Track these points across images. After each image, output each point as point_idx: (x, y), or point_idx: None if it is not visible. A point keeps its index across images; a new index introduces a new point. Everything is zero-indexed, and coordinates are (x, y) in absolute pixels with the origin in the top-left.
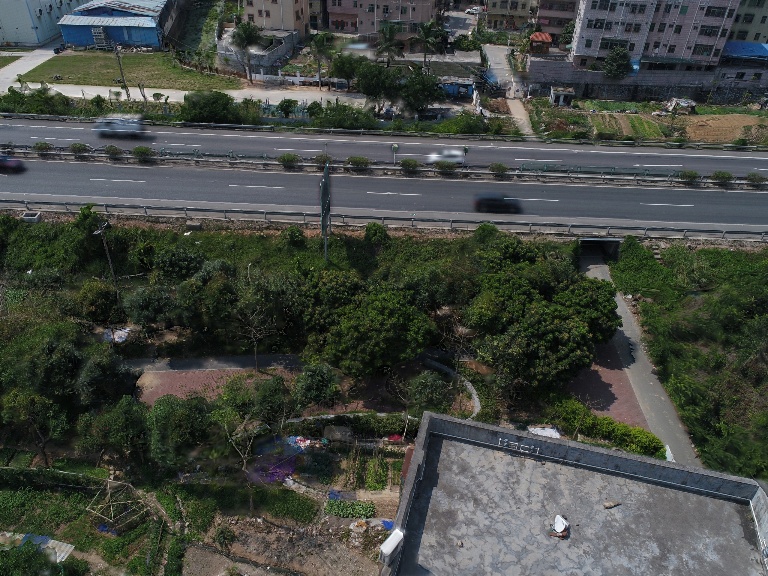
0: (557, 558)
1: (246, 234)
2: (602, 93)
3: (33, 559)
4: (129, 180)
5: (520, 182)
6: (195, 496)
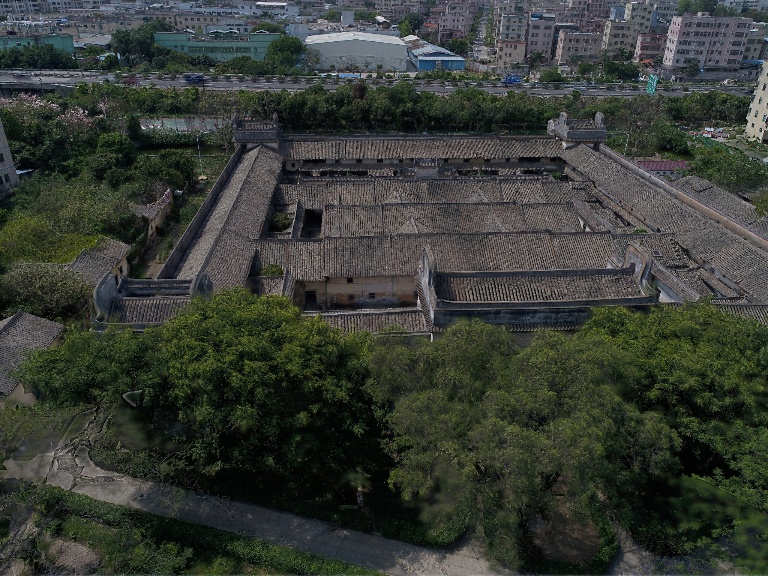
0: None
1: None
2: None
3: None
4: None
5: None
6: None
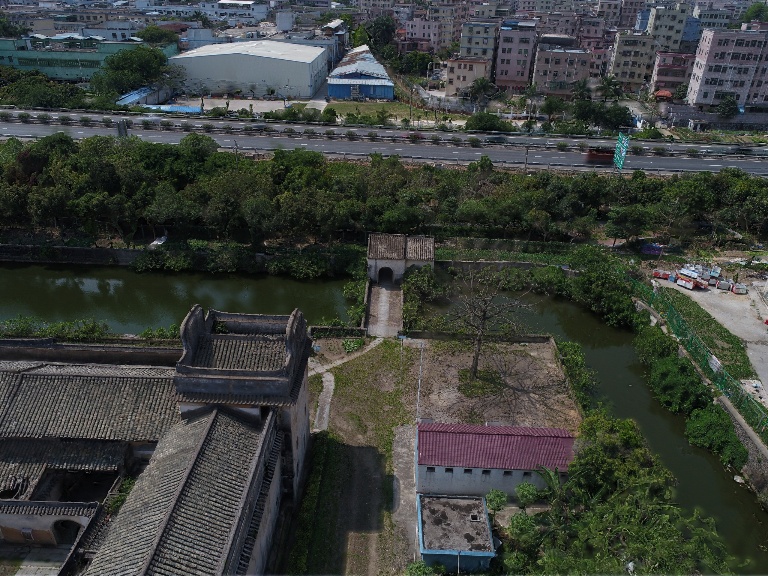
0: None
1: (563, 176)
2: (717, 129)
3: None
4: (476, 153)
5: (707, 159)
6: (625, 256)
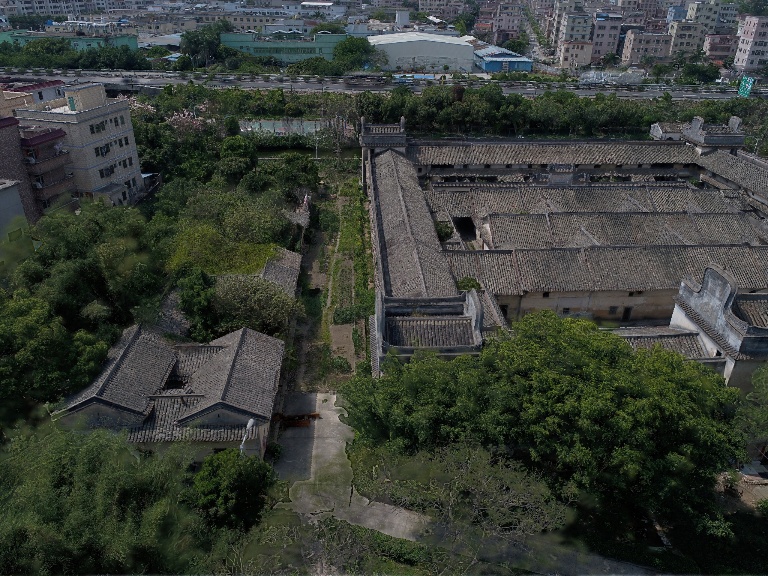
0: None
1: None
2: None
3: None
4: (646, 94)
5: None
6: None
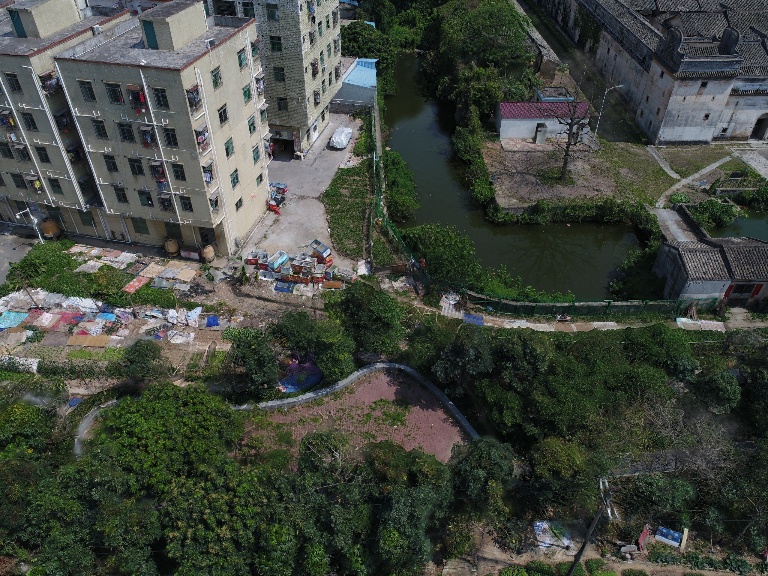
0: (151, 60)
1: None
2: None
3: (441, 262)
4: None
5: None
6: None
